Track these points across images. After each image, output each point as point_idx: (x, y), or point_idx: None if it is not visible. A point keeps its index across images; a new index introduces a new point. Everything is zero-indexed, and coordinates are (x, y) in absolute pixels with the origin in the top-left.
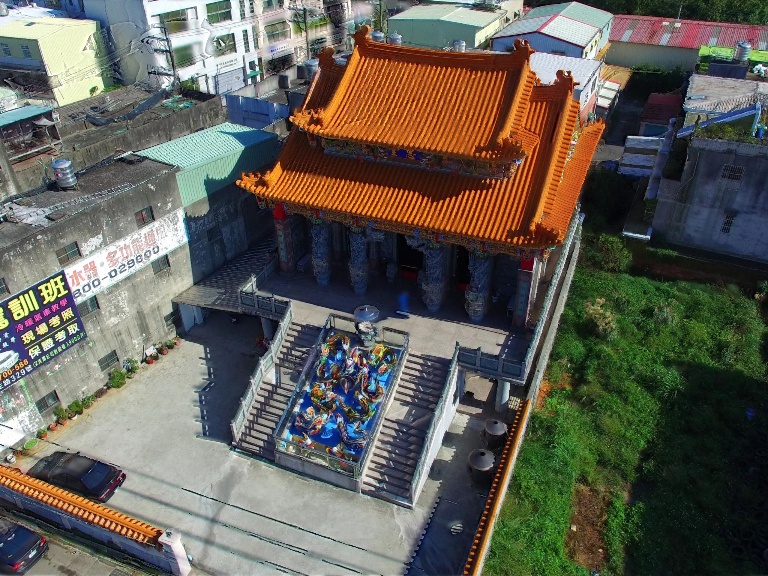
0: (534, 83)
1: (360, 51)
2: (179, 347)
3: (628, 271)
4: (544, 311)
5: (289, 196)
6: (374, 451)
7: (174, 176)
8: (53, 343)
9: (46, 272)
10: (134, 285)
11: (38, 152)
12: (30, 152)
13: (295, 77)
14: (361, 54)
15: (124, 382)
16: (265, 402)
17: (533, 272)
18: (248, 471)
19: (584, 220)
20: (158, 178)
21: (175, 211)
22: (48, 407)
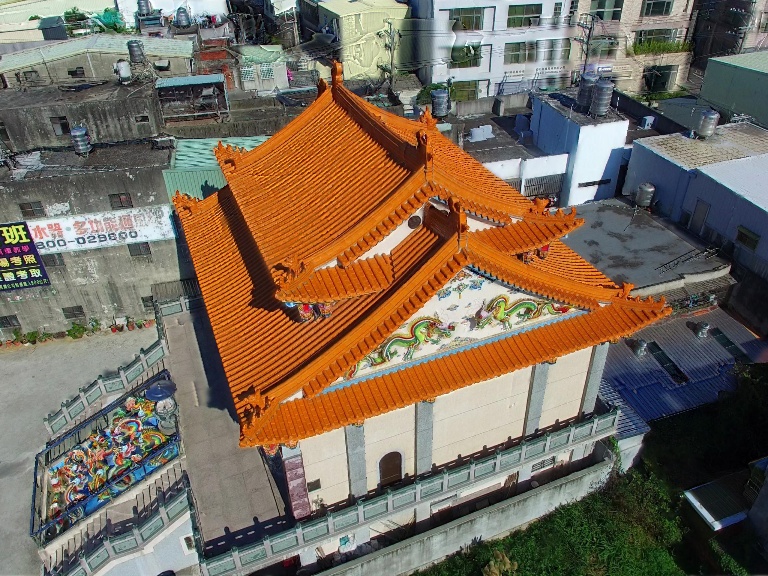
0: (445, 202)
1: (334, 93)
2: (145, 330)
3: (672, 553)
4: (328, 519)
5: (190, 231)
6: (77, 534)
7: (160, 172)
8: (15, 277)
9: (8, 218)
10: (106, 258)
11: (211, 116)
12: (197, 114)
13: (524, 105)
14: (334, 97)
15: (80, 336)
16: (86, 420)
17: (289, 459)
18: (28, 471)
19: (664, 436)
20: (140, 169)
21: (160, 205)
22: (11, 326)
